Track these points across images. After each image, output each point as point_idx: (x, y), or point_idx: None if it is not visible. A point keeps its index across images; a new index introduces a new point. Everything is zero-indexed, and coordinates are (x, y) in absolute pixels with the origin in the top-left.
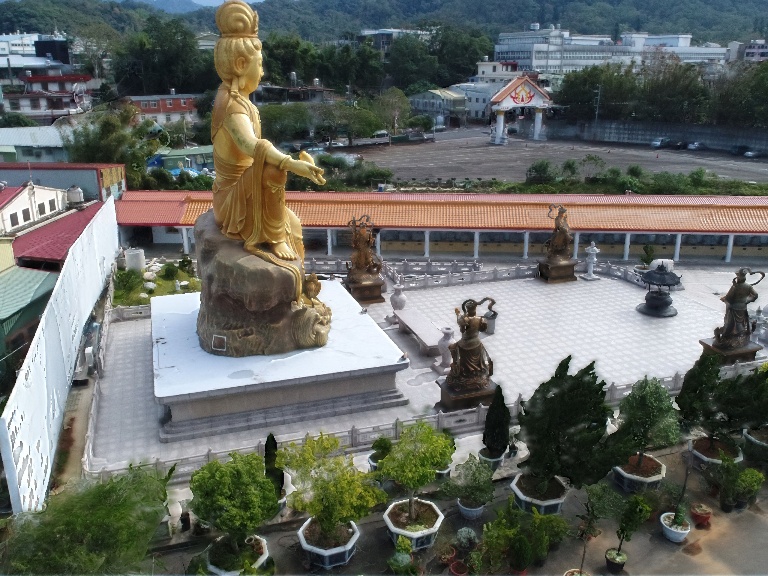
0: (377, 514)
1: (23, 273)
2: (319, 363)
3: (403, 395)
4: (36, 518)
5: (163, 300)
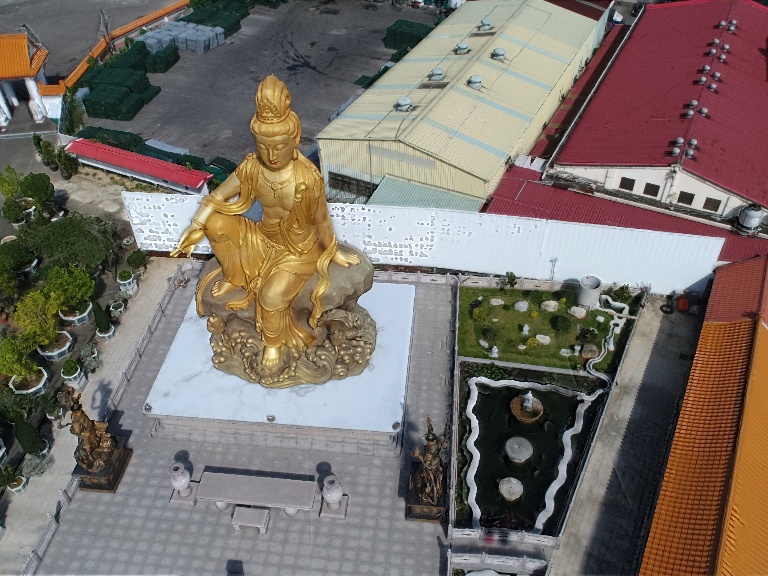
0: (64, 379)
1: (468, 206)
2: (186, 356)
3: (157, 430)
4: (75, 217)
5: (401, 291)
